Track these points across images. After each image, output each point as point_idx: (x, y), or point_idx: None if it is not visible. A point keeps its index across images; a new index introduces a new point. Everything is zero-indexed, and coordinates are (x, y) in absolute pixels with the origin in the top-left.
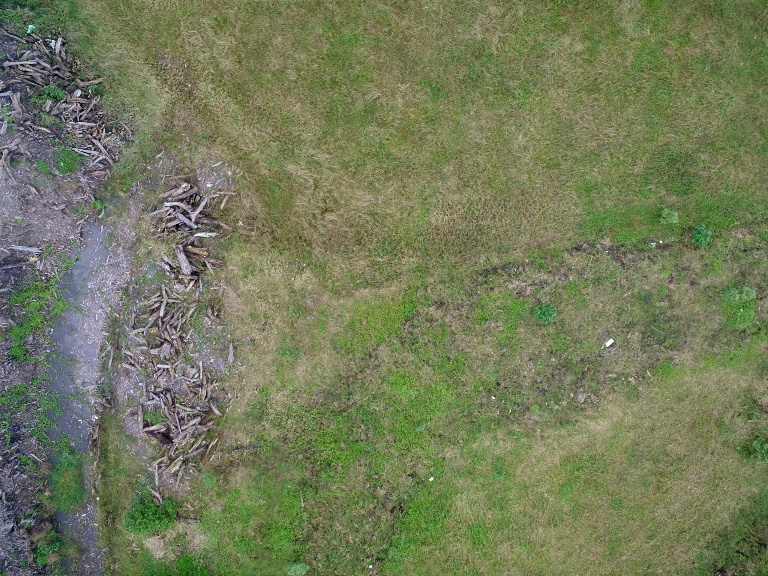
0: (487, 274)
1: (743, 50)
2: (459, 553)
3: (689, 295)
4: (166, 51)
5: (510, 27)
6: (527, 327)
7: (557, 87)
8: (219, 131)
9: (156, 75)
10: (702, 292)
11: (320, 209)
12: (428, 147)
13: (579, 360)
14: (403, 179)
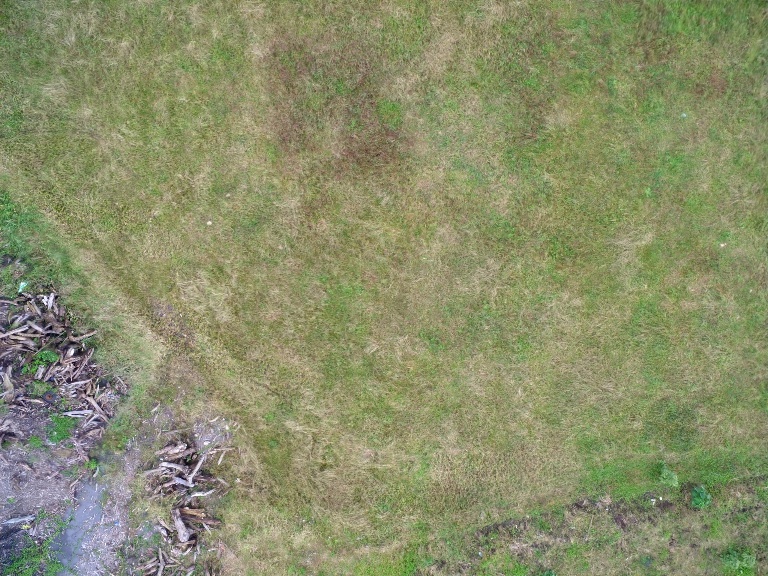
0: (488, 531)
1: (739, 304)
2: None
3: (689, 558)
4: (161, 300)
5: (508, 279)
6: None
7: (556, 340)
8: (216, 384)
9: (151, 326)
10: (702, 554)
11: (319, 464)
12: (427, 400)
13: None
14: (403, 434)
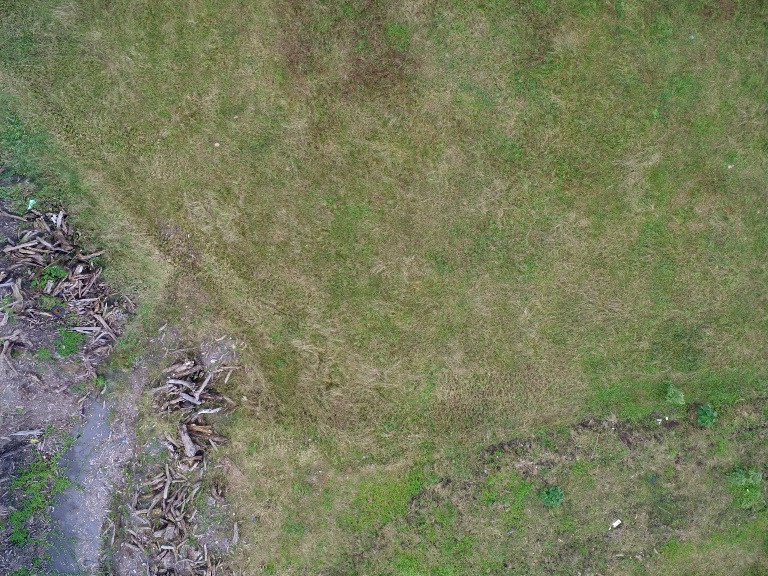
0: (493, 450)
1: (746, 225)
2: None
3: (695, 476)
4: (169, 221)
5: (515, 200)
6: (534, 508)
7: (562, 261)
8: (223, 303)
9: (159, 246)
10: (708, 473)
11: (325, 383)
12: (434, 321)
13: (586, 540)
14: (409, 354)
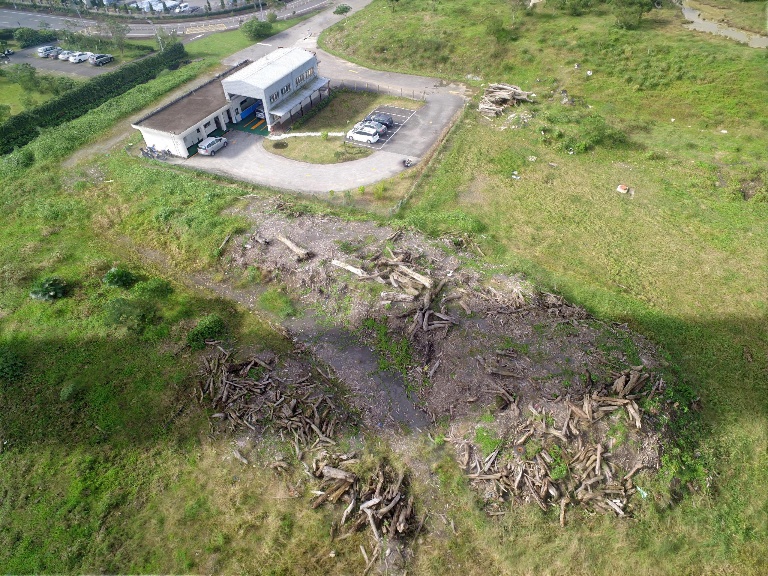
0: None
1: None
2: None
3: None
4: None
5: None
6: None
7: None
8: None
9: None
10: None
11: None
12: None
13: None
14: None
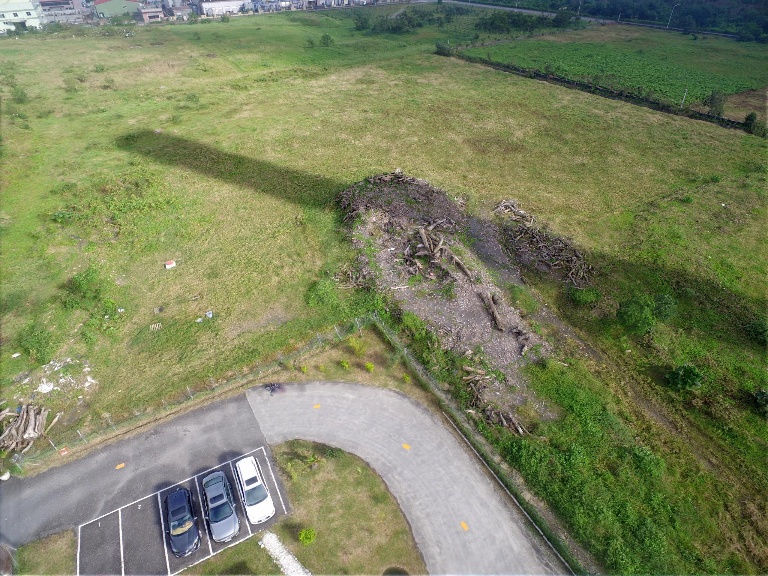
0: None
1: None
2: (760, 278)
3: None
4: None
5: None
6: (686, 206)
7: None
8: None
9: None
10: None
11: None
12: None
13: None
14: None
